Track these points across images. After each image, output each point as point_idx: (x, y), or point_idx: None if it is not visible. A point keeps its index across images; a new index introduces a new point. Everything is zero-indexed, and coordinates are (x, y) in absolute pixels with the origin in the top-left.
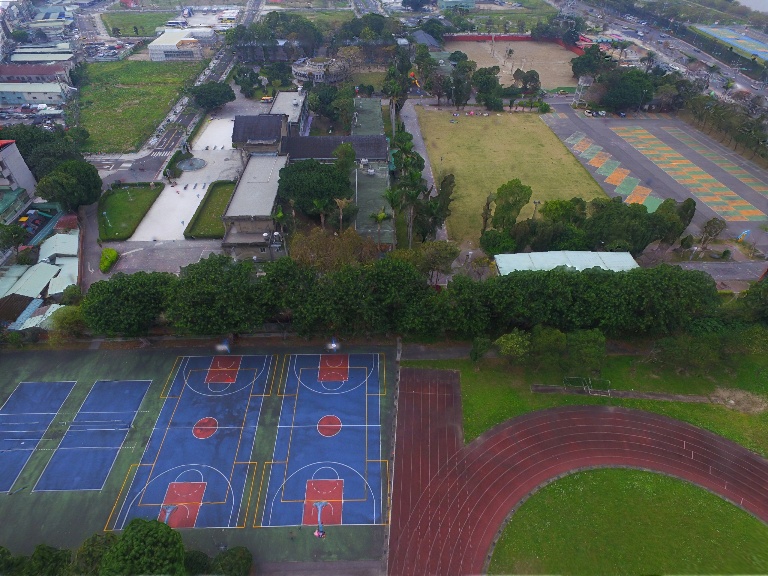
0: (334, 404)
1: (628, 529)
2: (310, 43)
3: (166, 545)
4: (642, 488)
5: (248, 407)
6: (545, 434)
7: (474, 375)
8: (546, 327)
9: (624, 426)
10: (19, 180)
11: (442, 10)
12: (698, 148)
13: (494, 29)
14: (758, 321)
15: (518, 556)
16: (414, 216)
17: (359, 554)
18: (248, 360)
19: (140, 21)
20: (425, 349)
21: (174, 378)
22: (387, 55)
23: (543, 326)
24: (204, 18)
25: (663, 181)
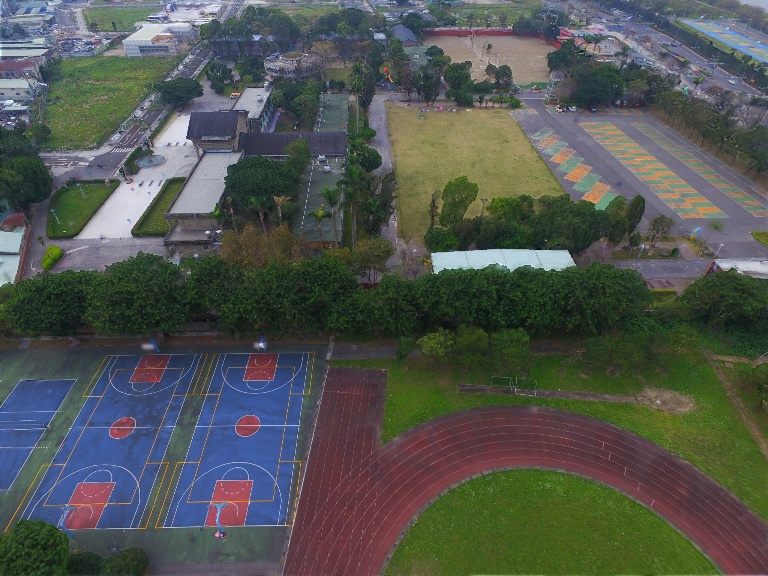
0: (256, 404)
1: (532, 531)
2: (284, 38)
3: (46, 547)
4: (553, 489)
5: (169, 407)
6: (464, 434)
7: (402, 374)
8: (470, 326)
9: (545, 426)
10: None
11: (427, 4)
12: (665, 144)
13: (477, 23)
14: (696, 320)
15: (417, 558)
16: (354, 214)
17: (257, 556)
18: (176, 359)
19: (121, 16)
20: (357, 348)
21: (99, 377)
22: (364, 50)
23: (467, 325)
24: (186, 13)
25: (624, 178)
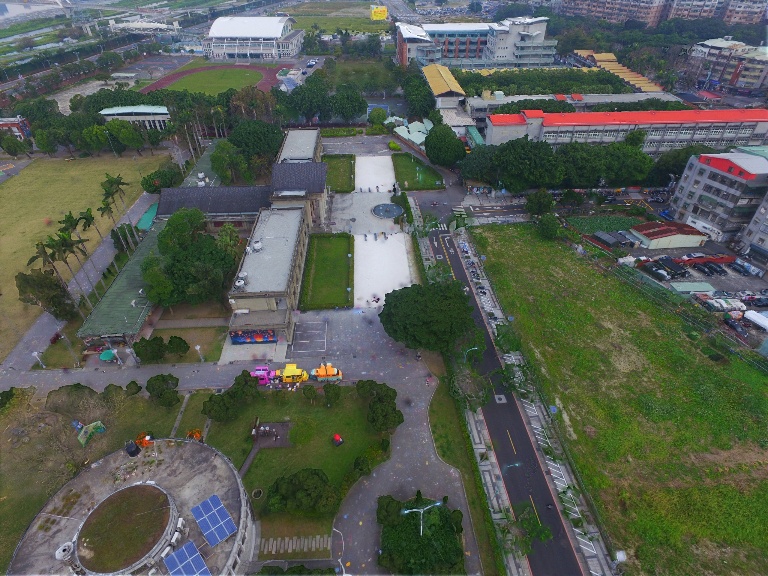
0: None
1: None
2: None
3: None
4: None
5: None
6: None
7: None
8: None
9: None
10: None
11: None
12: None
13: None
14: None
15: None
16: None
17: None
18: None
19: None
20: None
21: None
22: None
23: None
24: None
25: None
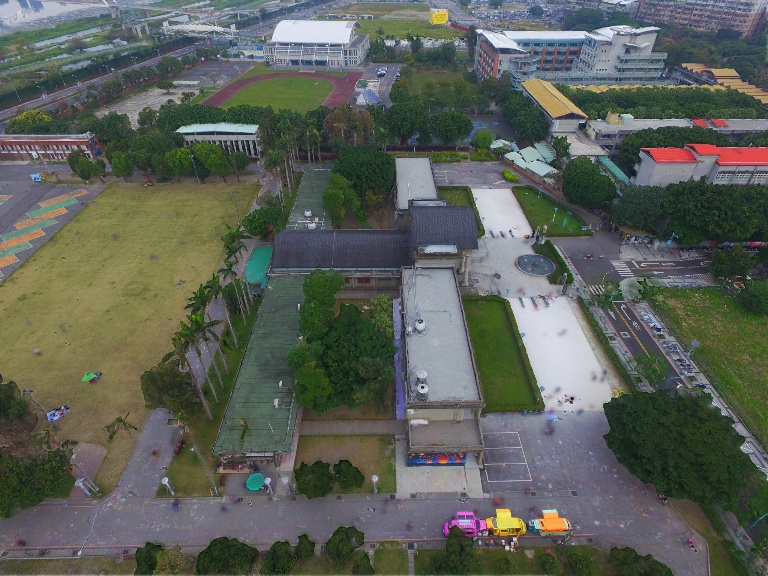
0: None
1: None
2: None
3: None
4: None
5: None
6: None
7: None
8: None
9: None
10: (637, 183)
11: None
12: None
13: None
14: None
15: None
16: None
17: None
18: None
19: None
20: None
21: None
22: None
23: None
24: None
25: None
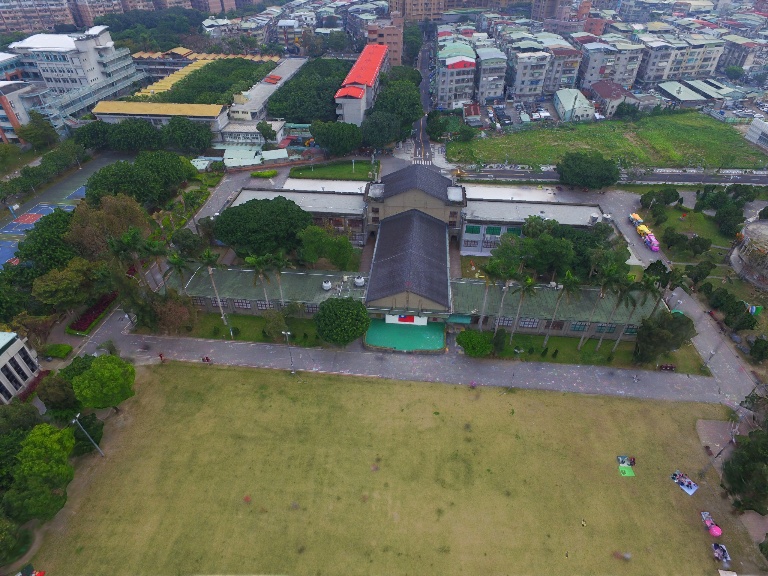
0: None
1: None
2: None
3: None
4: None
5: None
6: None
7: None
8: None
9: None
10: (348, 121)
11: None
12: None
13: None
14: None
15: None
16: None
17: None
18: None
19: None
20: None
21: None
22: None
23: None
24: None
25: None
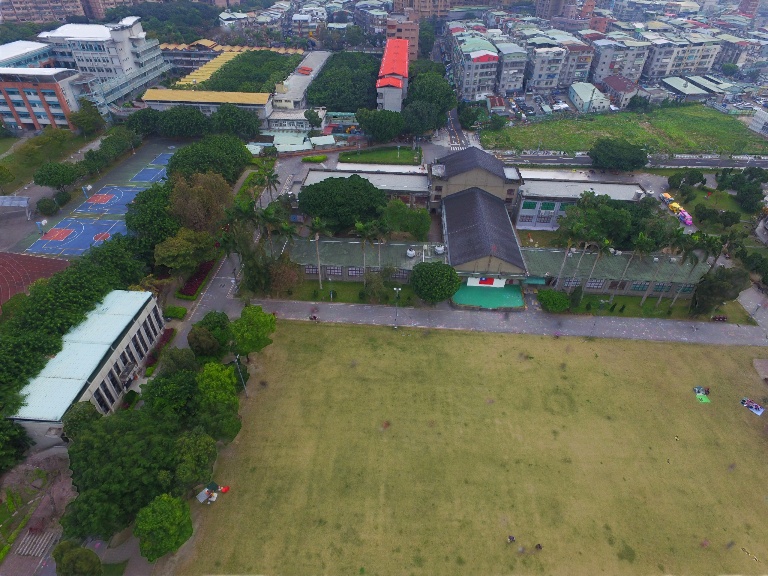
0: None
1: None
2: None
3: None
4: None
5: None
6: None
7: None
8: None
9: None
10: None
11: None
12: None
13: None
14: None
15: None
16: None
17: (18, 244)
18: None
19: None
20: None
21: None
22: None
23: None
24: None
25: None
